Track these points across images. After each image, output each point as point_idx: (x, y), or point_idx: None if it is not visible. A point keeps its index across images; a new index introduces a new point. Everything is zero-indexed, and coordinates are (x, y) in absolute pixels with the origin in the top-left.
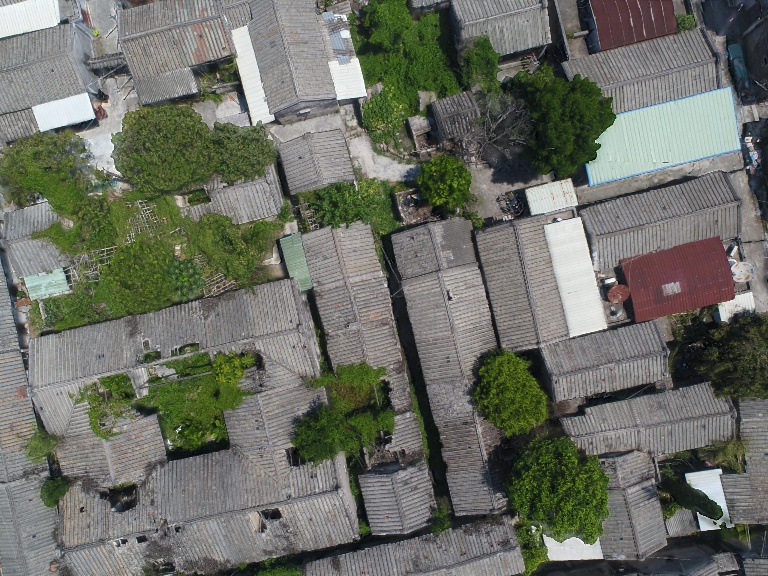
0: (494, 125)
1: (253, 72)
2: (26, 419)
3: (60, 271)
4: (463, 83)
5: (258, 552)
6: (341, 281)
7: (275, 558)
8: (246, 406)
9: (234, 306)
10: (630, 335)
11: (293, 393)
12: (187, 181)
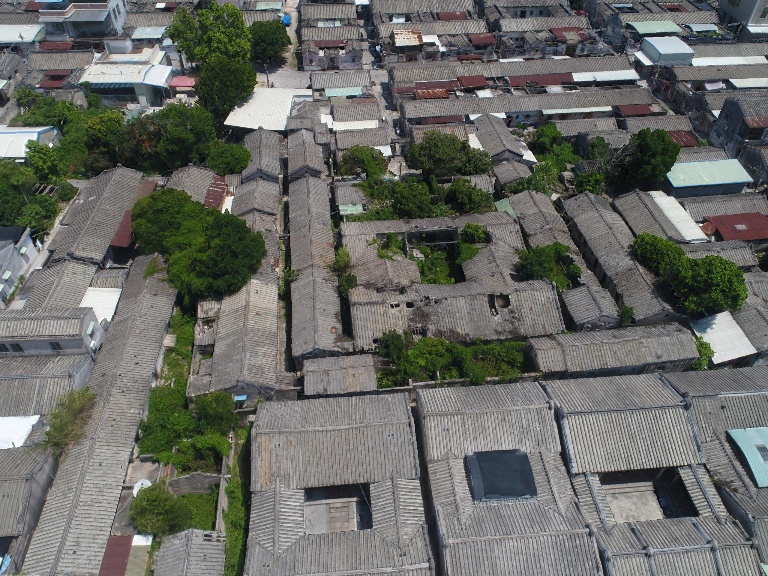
0: (615, 154)
1: (478, 146)
2: (330, 256)
3: (360, 205)
4: (590, 159)
5: (491, 331)
6: (537, 209)
7: (502, 341)
8: (481, 255)
9: (471, 217)
10: (724, 243)
11: (510, 254)
12: (453, 157)
